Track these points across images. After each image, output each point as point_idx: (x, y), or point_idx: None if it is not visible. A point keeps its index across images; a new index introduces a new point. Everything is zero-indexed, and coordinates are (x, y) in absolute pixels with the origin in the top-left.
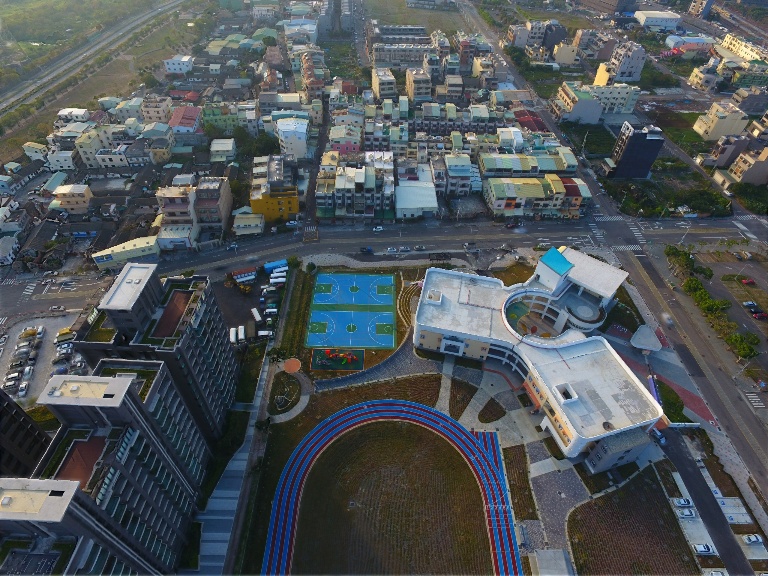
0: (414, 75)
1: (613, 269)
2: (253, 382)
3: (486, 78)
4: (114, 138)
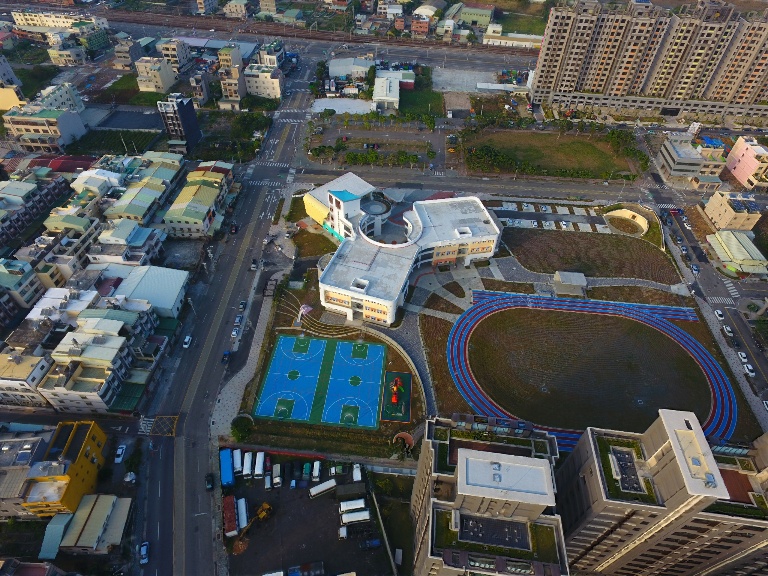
0: None
1: (344, 178)
2: None
3: None
4: None
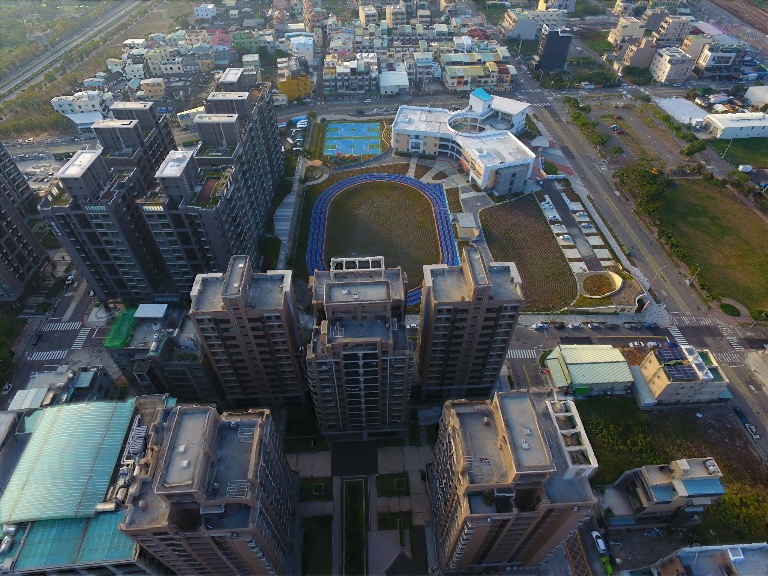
0: (392, 9)
1: (521, 103)
2: (293, 169)
3: (449, 10)
4: (170, 56)
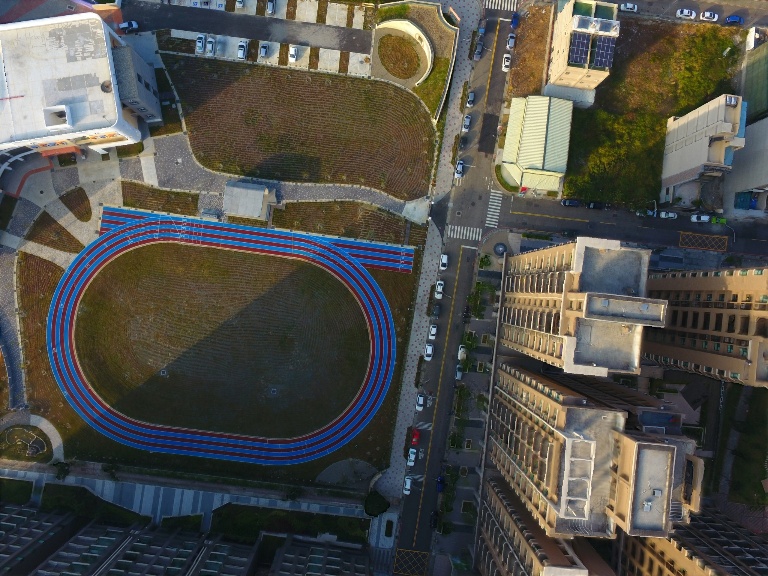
0: None
1: None
2: (3, 484)
3: None
4: None
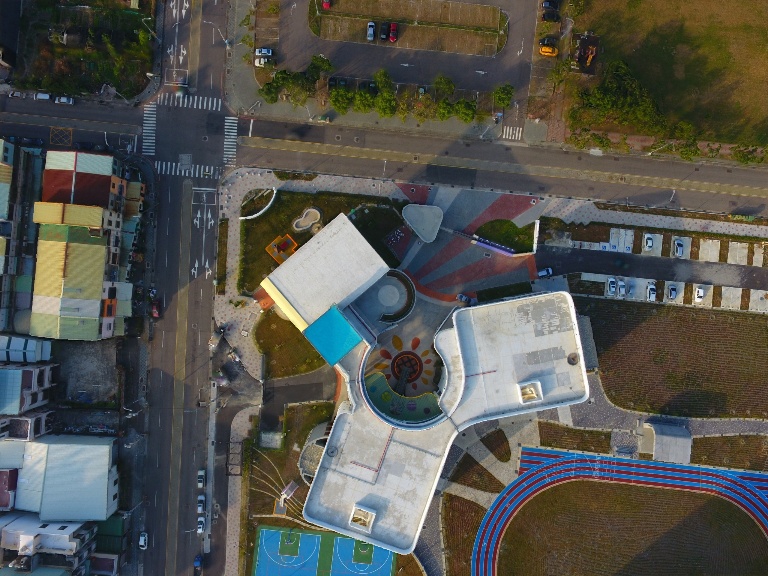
0: None
1: (330, 232)
2: None
3: None
4: None
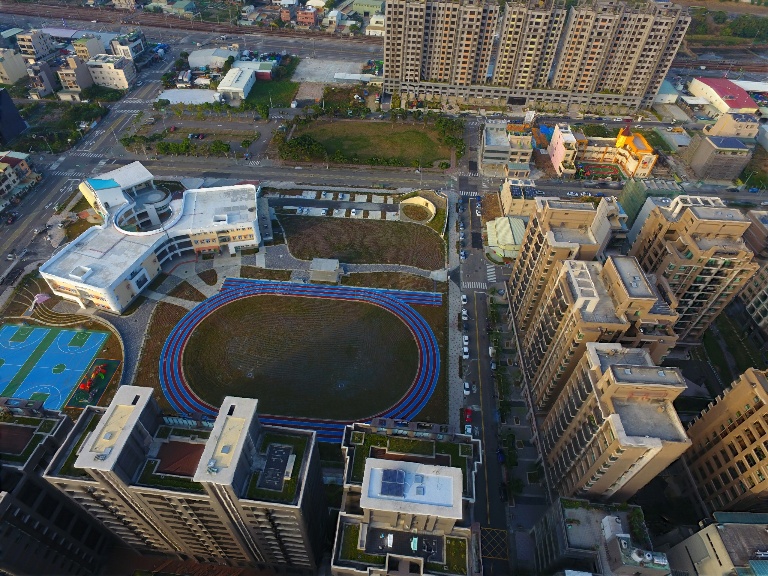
0: None
1: (128, 167)
2: None
3: None
4: None
